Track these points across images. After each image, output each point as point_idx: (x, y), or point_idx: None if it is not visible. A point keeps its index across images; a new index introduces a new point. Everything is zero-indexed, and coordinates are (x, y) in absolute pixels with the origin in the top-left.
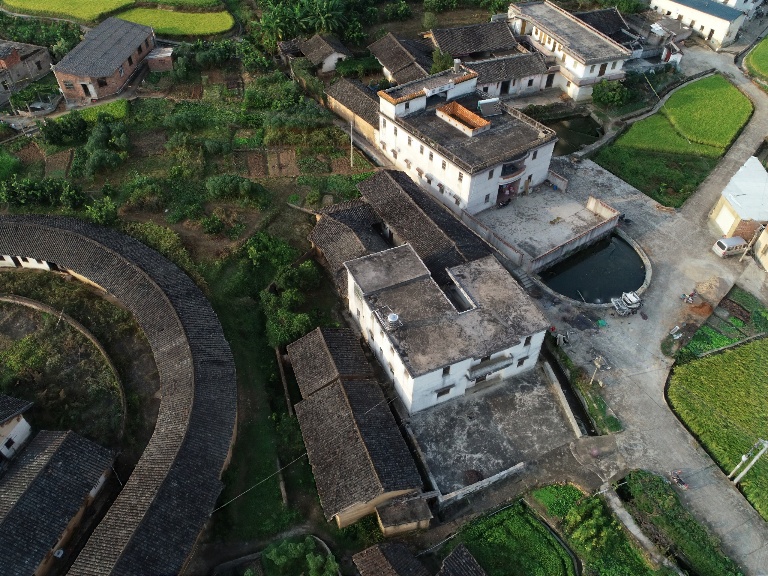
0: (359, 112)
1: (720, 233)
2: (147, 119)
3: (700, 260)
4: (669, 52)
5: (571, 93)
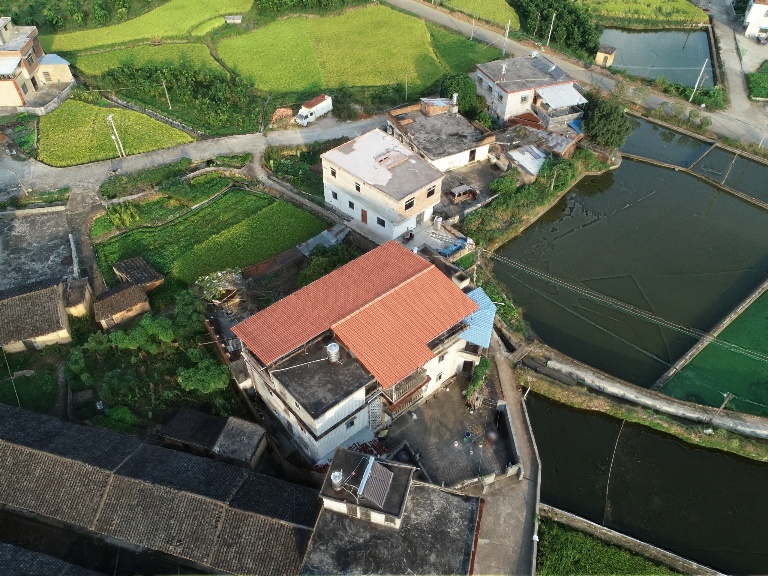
0: None
1: None
2: None
3: None
4: None
5: None
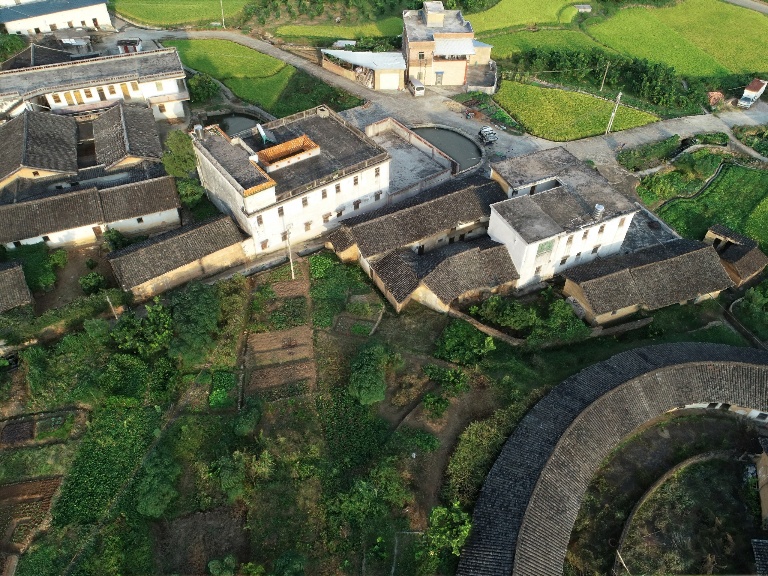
0: (208, 250)
1: (395, 91)
2: (111, 566)
3: (425, 104)
4: (126, 47)
5: (172, 114)
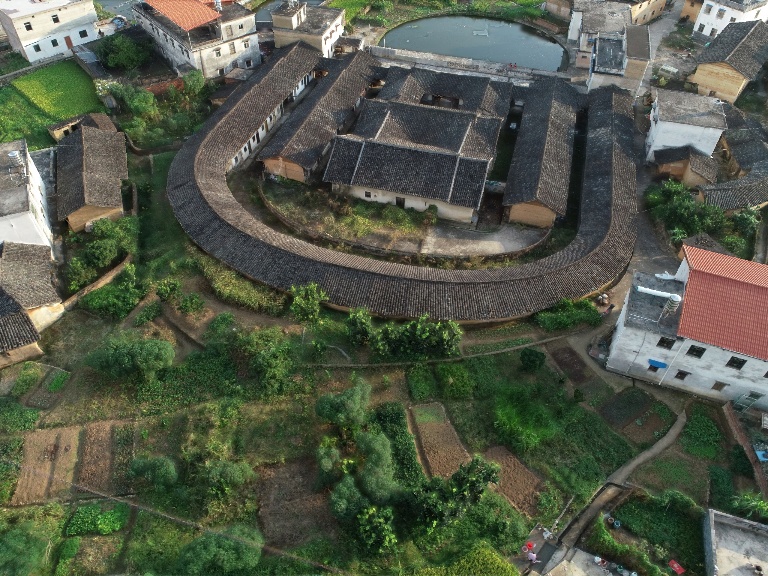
0: None
1: None
2: None
3: None
4: None
5: None
